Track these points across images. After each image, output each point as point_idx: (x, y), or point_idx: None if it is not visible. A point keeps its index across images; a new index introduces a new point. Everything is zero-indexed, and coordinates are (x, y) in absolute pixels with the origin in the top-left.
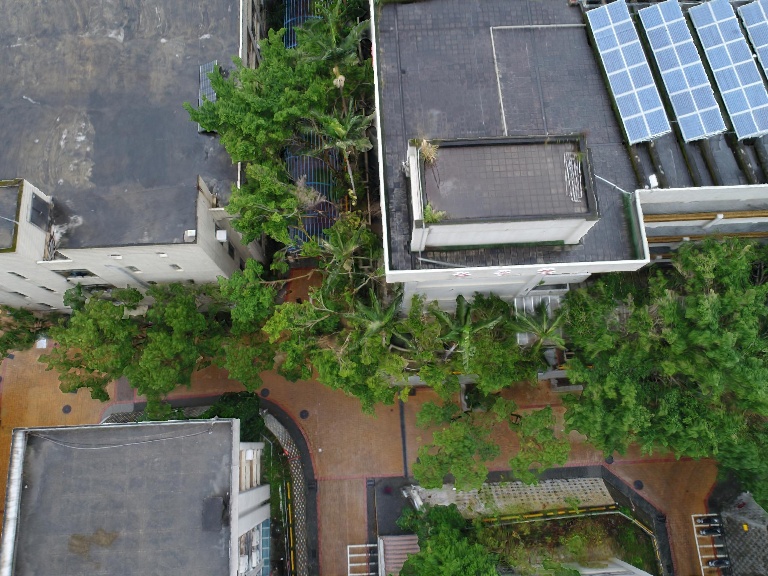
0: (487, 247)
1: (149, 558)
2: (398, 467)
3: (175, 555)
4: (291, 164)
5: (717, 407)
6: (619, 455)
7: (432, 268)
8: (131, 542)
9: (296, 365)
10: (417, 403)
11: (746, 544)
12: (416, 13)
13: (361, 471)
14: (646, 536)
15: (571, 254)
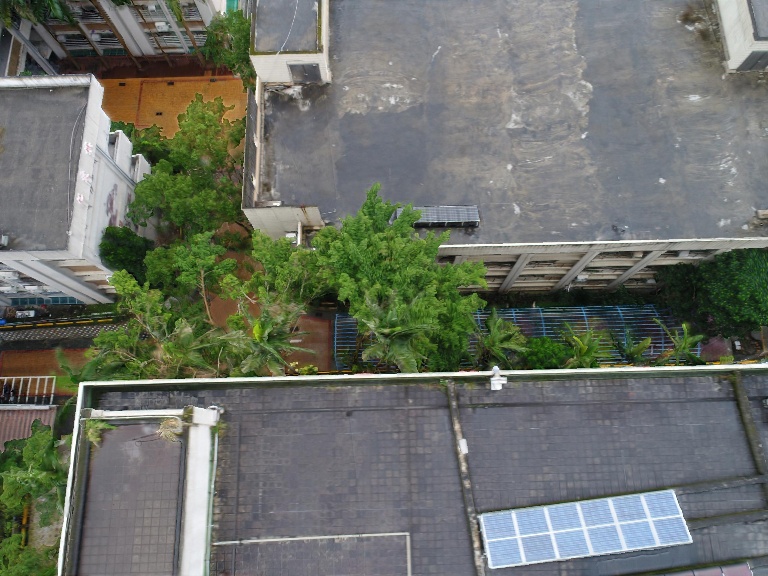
0: None
1: None
2: None
3: None
4: None
5: None
6: None
7: None
8: None
9: None
10: None
11: None
12: (434, 433)
13: None
14: None
15: None
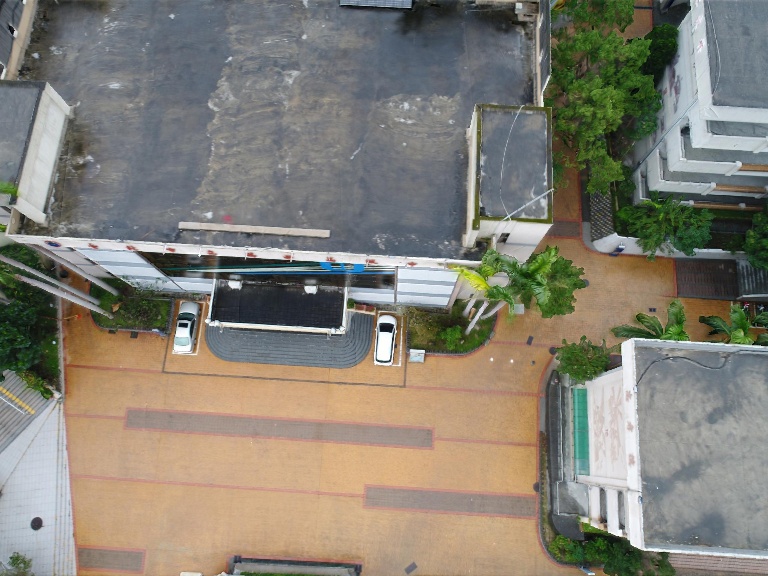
0: None
1: None
2: (645, 13)
3: None
4: None
5: None
6: None
7: None
8: None
9: None
10: None
11: None
12: None
13: None
14: None
15: None
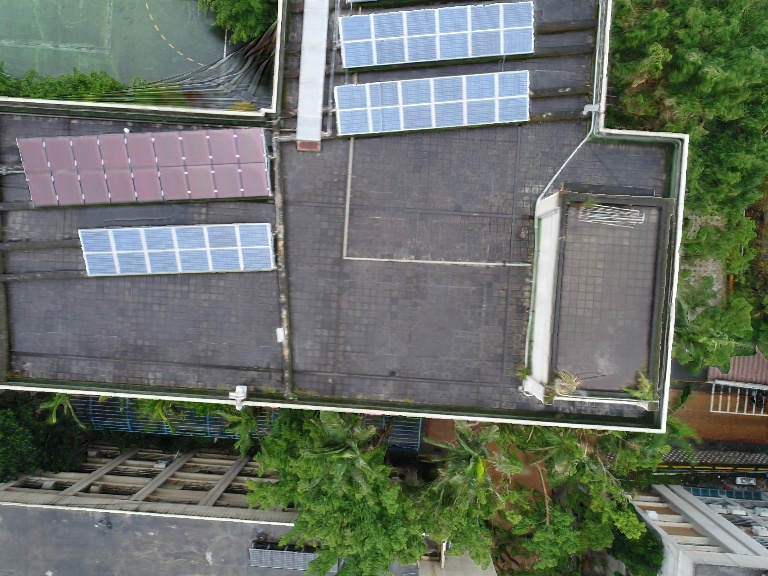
0: None
1: None
2: None
3: None
4: None
5: None
6: None
7: None
8: None
9: (619, 484)
10: None
11: None
12: (311, 347)
13: None
14: None
15: None
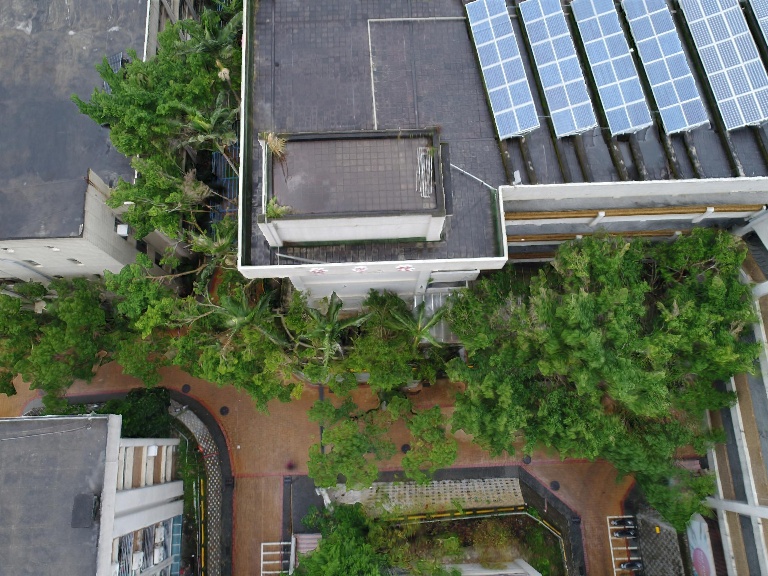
0: (347, 243)
1: (20, 554)
2: None
3: (46, 551)
4: (217, 159)
5: (595, 408)
6: (537, 455)
7: (288, 264)
8: (3, 537)
9: (186, 361)
10: (337, 401)
11: (658, 547)
12: (294, 5)
13: (278, 468)
14: (554, 537)
15: (433, 251)
